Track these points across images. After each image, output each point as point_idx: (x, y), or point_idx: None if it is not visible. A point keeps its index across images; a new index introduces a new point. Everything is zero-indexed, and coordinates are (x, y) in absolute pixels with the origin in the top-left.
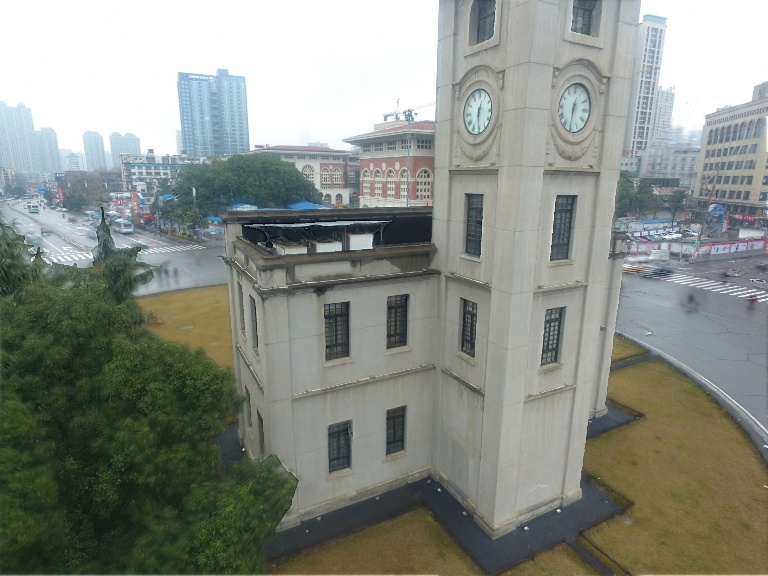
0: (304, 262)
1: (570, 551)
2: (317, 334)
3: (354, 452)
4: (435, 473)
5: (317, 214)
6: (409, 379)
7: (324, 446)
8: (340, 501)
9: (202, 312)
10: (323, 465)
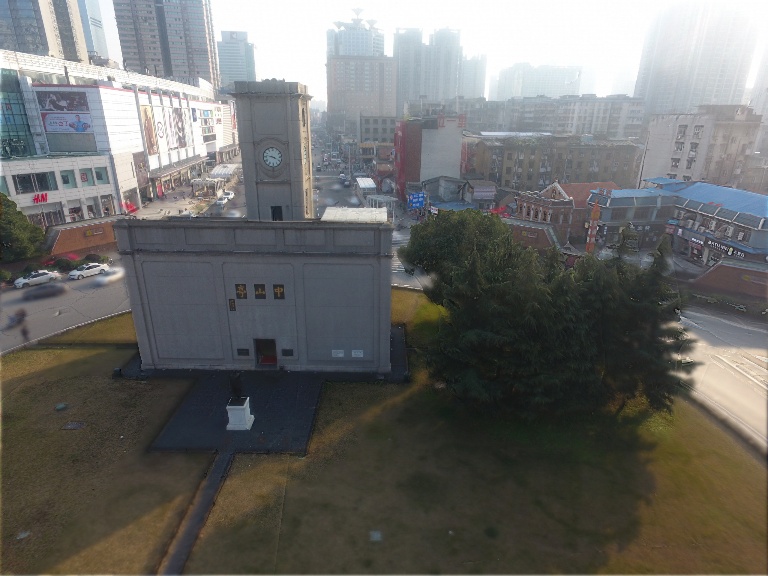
0: None
1: None
2: None
3: None
4: None
5: None
6: None
7: None
8: None
9: None
10: None
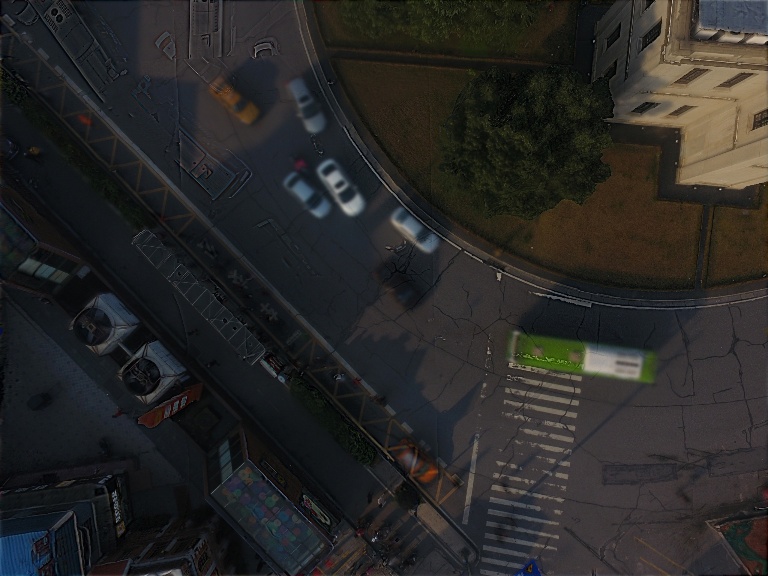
0: (703, 51)
1: (701, 210)
2: (677, 76)
3: (649, 111)
4: (684, 131)
5: None
6: (713, 100)
7: (636, 106)
8: (624, 121)
9: None
10: (629, 111)
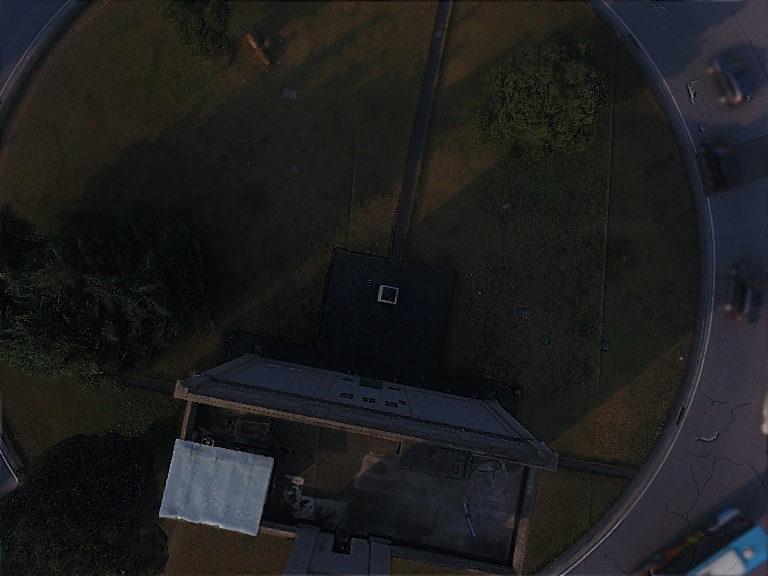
0: None
1: None
2: None
3: None
4: None
5: (261, 414)
6: None
7: None
8: None
9: (321, 49)
10: None
